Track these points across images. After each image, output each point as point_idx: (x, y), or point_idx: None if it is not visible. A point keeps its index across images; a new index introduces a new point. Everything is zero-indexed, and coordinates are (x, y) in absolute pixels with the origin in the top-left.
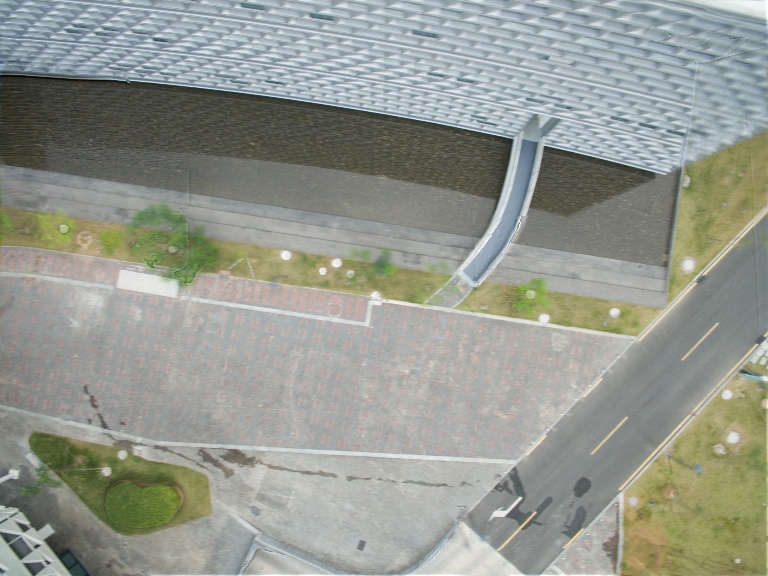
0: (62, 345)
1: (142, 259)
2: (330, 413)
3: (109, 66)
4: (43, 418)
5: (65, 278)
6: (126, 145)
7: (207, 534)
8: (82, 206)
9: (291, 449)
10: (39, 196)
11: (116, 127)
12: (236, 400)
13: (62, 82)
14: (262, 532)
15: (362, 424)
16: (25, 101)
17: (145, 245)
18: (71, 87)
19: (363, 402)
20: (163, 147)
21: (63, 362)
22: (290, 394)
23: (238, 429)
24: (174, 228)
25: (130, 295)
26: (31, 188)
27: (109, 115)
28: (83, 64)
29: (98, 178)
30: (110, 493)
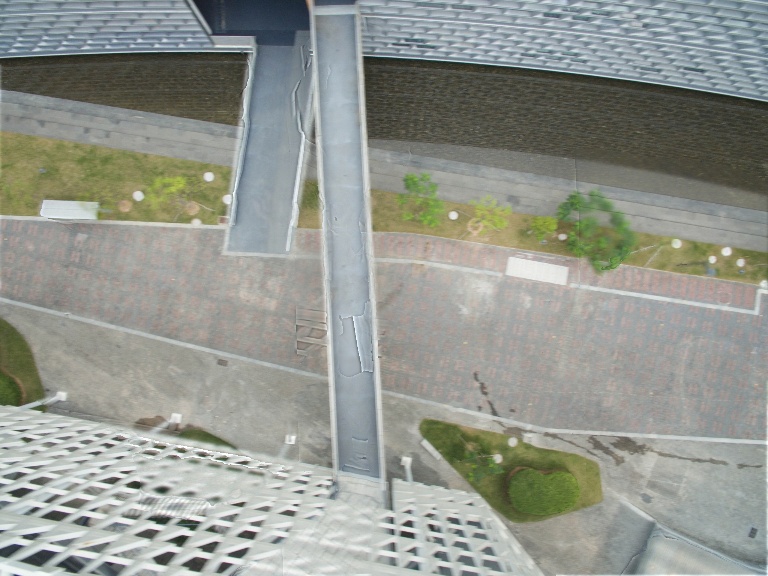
0: (451, 332)
1: (531, 246)
2: (720, 401)
3: (526, 53)
4: (432, 405)
5: (454, 265)
6: (513, 132)
7: (599, 521)
8: (473, 193)
9: (681, 437)
10: (428, 183)
11: (504, 114)
12: (626, 387)
13: (479, 68)
14: (656, 519)
15: (752, 412)
16: (434, 87)
17: (536, 232)
18: (484, 73)
19: (753, 390)
20: (550, 135)
21: (453, 349)
22: (680, 382)
23: (629, 416)
24: (565, 215)
25: (519, 282)
26: (422, 174)
27: (501, 102)
28: (505, 50)
29: (485, 165)
30: (514, 480)
